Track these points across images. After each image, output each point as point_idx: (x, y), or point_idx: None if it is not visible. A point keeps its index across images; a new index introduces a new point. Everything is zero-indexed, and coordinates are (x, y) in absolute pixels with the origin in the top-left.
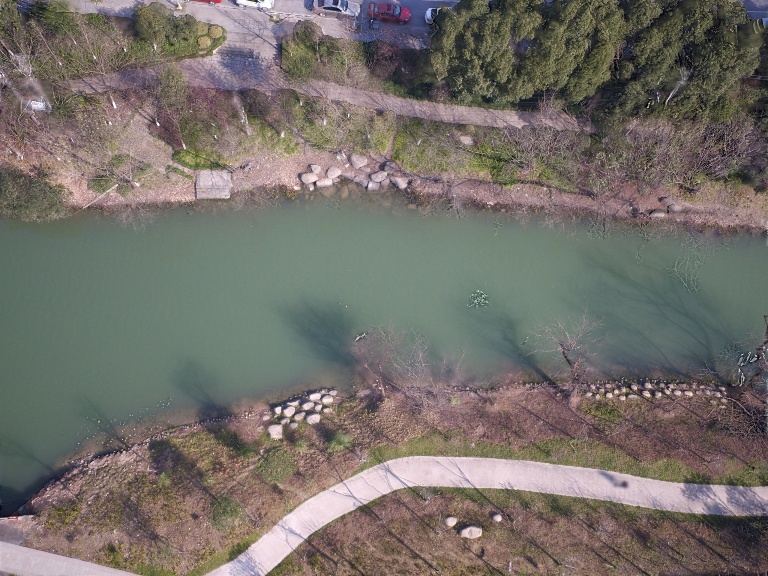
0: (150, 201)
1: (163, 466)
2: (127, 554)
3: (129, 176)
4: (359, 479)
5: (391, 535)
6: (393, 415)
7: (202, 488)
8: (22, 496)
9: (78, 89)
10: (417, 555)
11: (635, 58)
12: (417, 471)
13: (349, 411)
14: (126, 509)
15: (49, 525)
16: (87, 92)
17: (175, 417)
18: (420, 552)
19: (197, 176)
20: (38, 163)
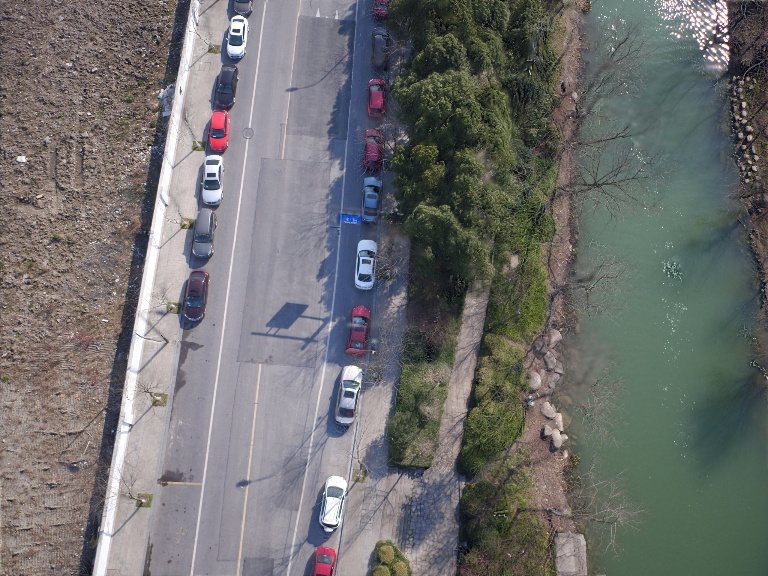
0: None
1: None
2: None
3: None
4: None
5: None
6: None
7: None
8: None
9: None
10: None
11: None
12: None
13: None
14: None
15: None
16: None
17: None
18: None
19: (564, 575)
20: None
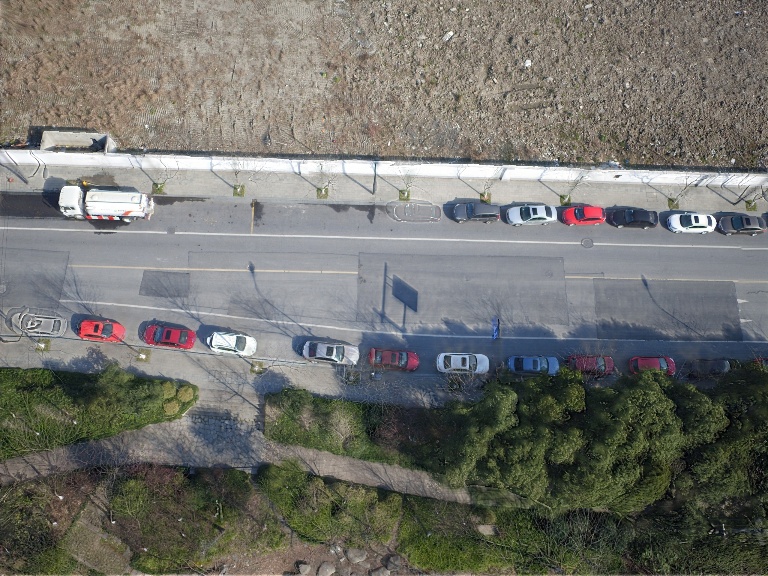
0: None
1: None
2: None
3: None
4: None
5: None
6: None
7: None
8: None
9: (17, 472)
10: None
11: (695, 475)
12: None
13: None
14: None
15: None
16: (28, 476)
17: None
18: None
19: None
20: None
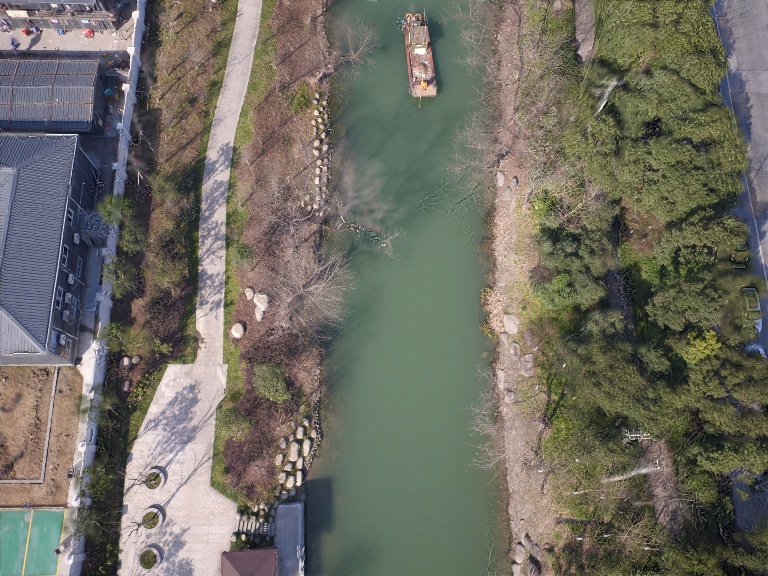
0: None
1: None
2: None
3: None
4: None
5: None
6: None
7: None
8: None
9: None
10: None
11: None
12: None
13: None
14: None
15: None
16: None
17: None
18: None
19: None
20: None
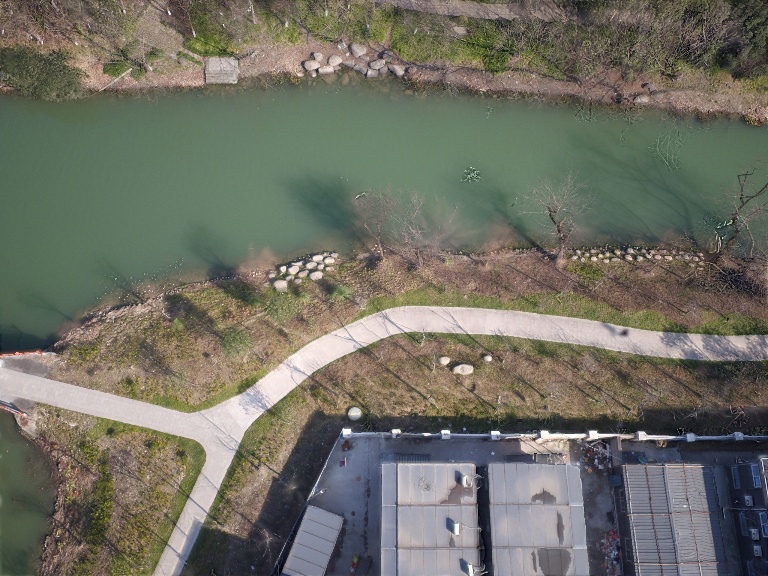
0: (162, 85)
1: (176, 315)
2: (144, 387)
3: (142, 60)
4: (359, 325)
5: (389, 372)
6: (391, 272)
7: (213, 332)
8: (45, 341)
9: None
10: (413, 389)
11: None
12: (413, 319)
13: (349, 270)
14: (142, 349)
15: (71, 361)
16: None
17: (187, 276)
18: (416, 386)
19: (206, 62)
20: (57, 48)
